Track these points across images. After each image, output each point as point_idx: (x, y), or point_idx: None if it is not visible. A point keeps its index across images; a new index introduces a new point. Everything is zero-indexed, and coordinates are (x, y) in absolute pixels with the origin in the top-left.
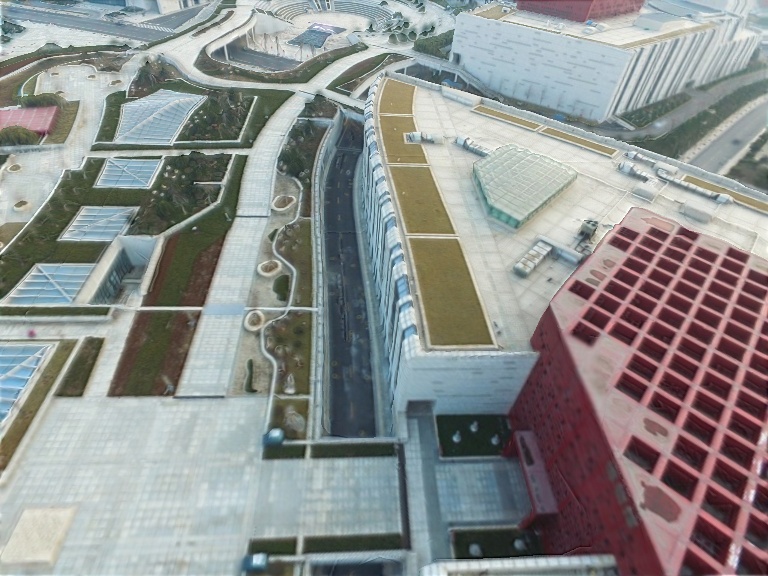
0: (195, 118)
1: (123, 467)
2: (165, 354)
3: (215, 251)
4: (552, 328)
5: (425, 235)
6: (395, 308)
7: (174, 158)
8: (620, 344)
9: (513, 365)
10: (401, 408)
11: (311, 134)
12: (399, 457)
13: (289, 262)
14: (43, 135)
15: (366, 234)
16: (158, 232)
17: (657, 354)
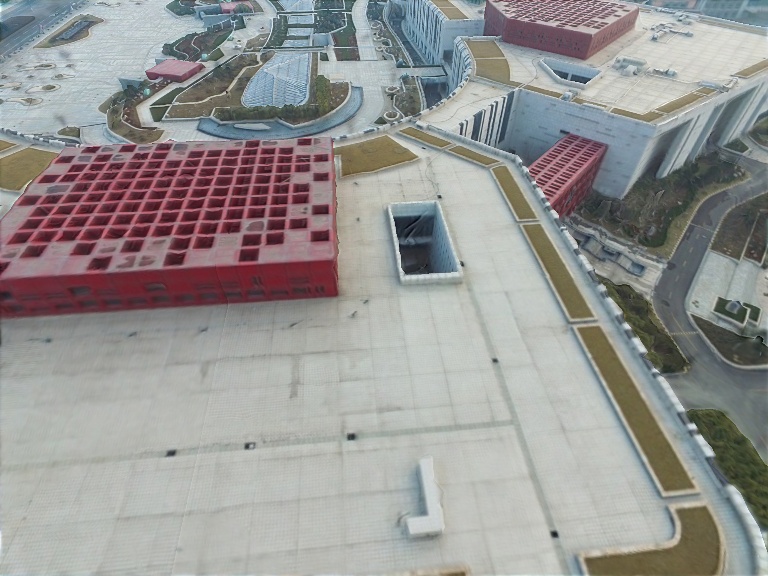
0: (318, 3)
1: (353, 69)
2: (351, 54)
3: (354, 37)
4: (487, 4)
5: (444, 7)
6: (437, 21)
7: (320, 13)
8: (506, 2)
9: (478, 26)
10: (441, 56)
11: (377, 8)
12: (442, 67)
13: (386, 38)
14: (251, 10)
15: (414, 41)
16: (327, 32)
17: (517, 3)
